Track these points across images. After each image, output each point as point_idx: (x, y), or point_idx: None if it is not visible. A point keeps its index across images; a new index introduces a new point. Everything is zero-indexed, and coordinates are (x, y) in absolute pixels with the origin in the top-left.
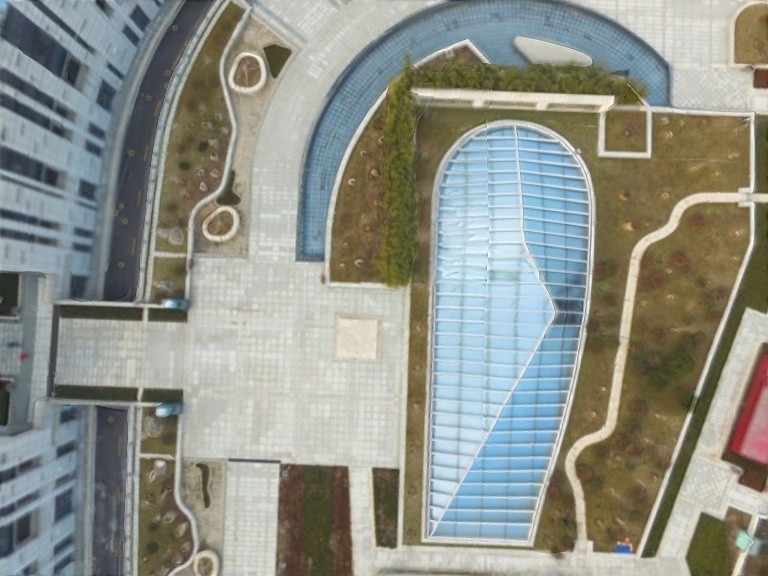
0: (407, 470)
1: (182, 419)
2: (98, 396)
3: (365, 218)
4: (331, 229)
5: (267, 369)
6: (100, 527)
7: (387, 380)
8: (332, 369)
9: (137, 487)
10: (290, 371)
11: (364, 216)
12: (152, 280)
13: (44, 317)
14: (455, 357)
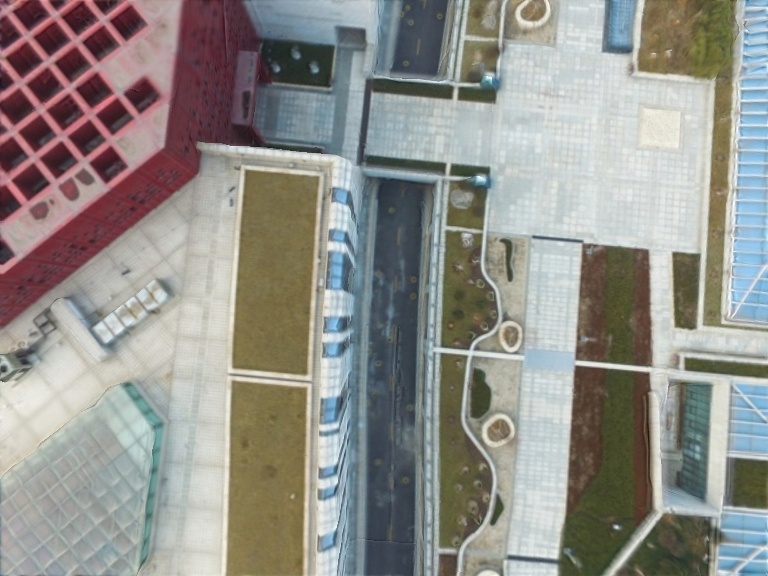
0: (708, 254)
1: (490, 194)
2: (408, 168)
3: (673, 14)
4: (641, 21)
5: (572, 152)
6: (377, 313)
7: (688, 170)
8: (635, 156)
9: (442, 258)
10: (594, 156)
11: (672, 12)
12: (461, 62)
13: (356, 90)
14: (760, 147)
